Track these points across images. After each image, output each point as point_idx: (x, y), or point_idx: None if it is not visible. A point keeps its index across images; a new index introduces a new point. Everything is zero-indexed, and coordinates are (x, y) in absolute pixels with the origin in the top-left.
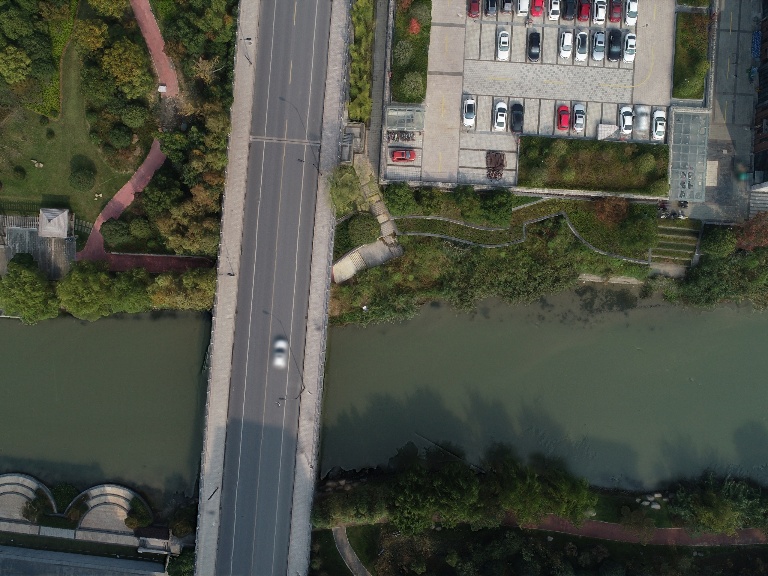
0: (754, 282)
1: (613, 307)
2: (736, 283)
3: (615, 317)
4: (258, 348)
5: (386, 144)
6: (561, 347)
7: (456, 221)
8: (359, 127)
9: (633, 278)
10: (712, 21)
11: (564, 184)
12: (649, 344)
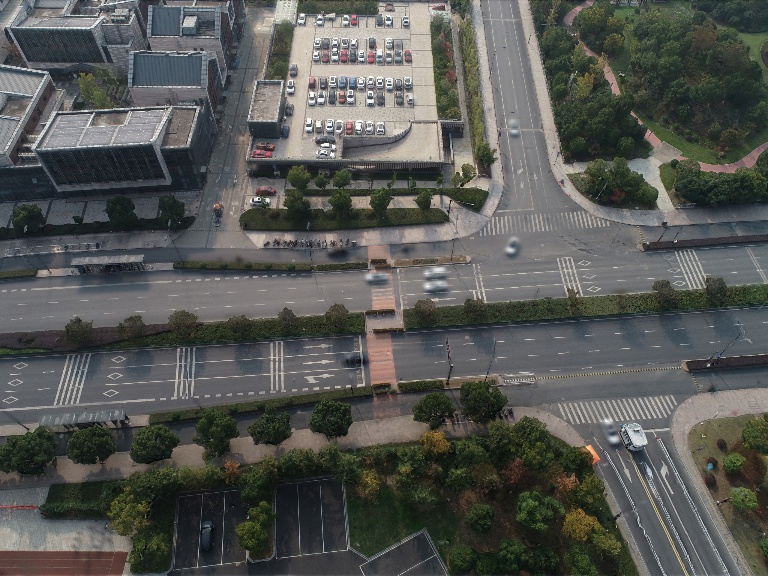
0: None
1: None
2: None
3: None
4: None
5: None
6: None
7: None
8: None
9: None
10: None
11: None
12: None
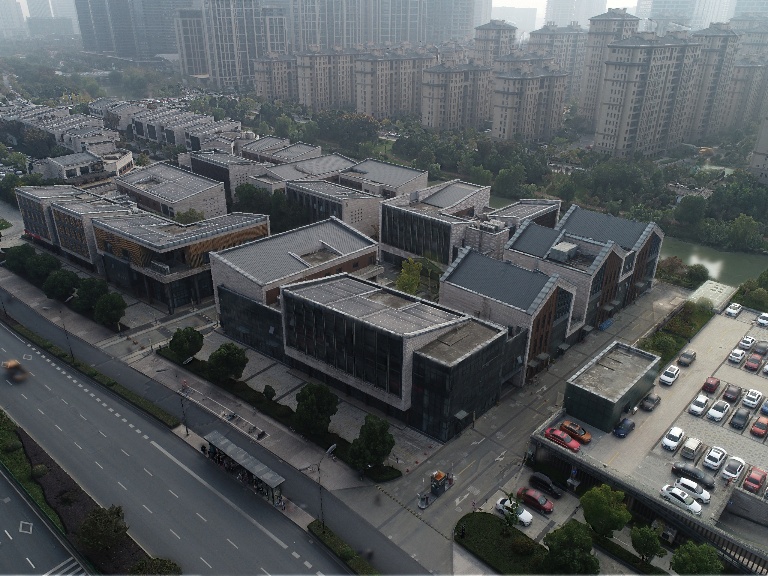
0: None
1: None
2: None
3: None
4: None
5: None
6: None
7: None
8: None
9: None
10: None
11: None
12: None
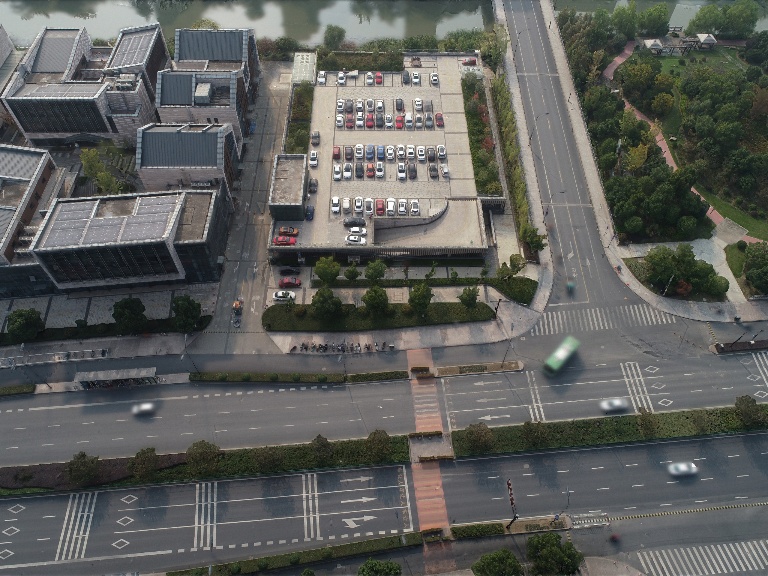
0: None
1: None
2: None
3: None
4: (528, 8)
5: None
6: (365, 30)
7: None
8: None
9: None
10: None
11: None
12: (317, 30)
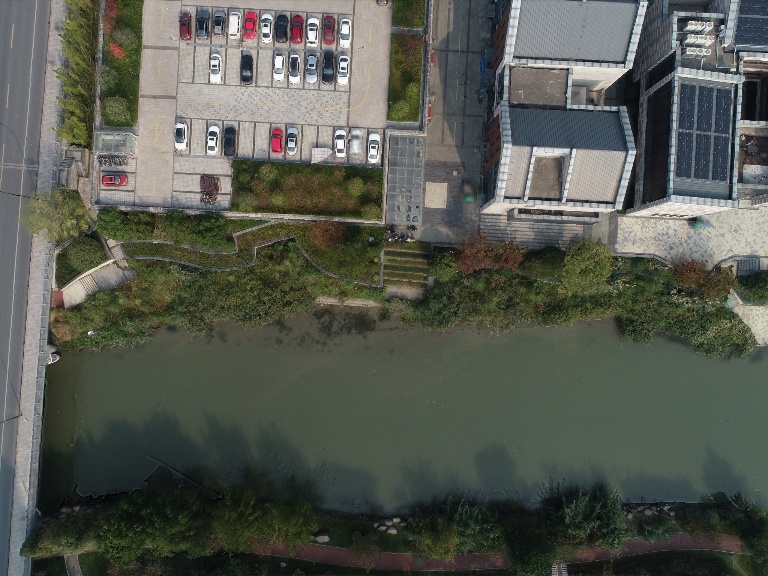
0: (484, 305)
1: (351, 330)
2: (469, 306)
3: (354, 340)
4: None
5: (98, 168)
6: (299, 371)
7: (182, 245)
8: (80, 151)
9: (371, 301)
10: (427, 43)
11: (278, 208)
12: (387, 367)
